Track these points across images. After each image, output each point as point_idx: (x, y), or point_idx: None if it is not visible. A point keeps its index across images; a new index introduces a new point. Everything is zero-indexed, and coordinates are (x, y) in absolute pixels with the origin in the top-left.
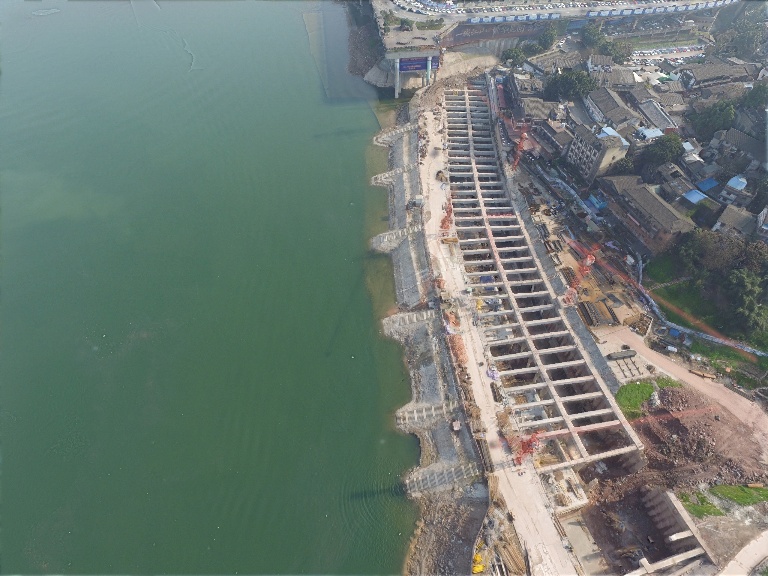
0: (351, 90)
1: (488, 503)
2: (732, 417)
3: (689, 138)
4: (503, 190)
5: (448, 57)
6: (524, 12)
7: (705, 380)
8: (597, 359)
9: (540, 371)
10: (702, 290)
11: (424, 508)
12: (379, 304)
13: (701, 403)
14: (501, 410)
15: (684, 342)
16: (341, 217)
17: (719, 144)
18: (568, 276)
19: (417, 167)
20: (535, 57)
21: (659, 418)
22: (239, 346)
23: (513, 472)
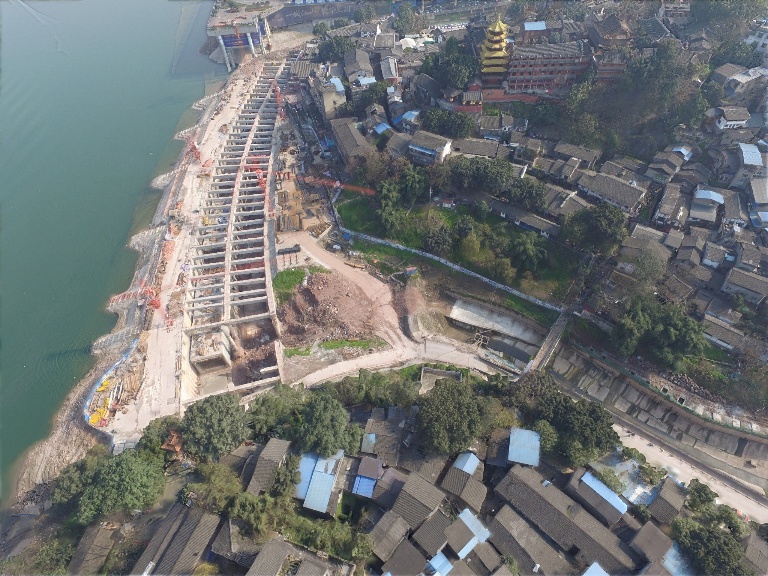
0: (194, 66)
1: (134, 350)
2: (362, 294)
3: (395, 84)
4: (270, 138)
5: (282, 36)
6: None
7: (355, 269)
8: (272, 255)
9: (225, 265)
10: (373, 202)
11: (99, 360)
12: (136, 226)
13: (340, 284)
14: (177, 290)
15: (349, 242)
16: (136, 164)
17: (415, 87)
18: (280, 197)
19: (208, 122)
20: (335, 30)
21: (305, 296)
22: (11, 257)
23: (164, 330)
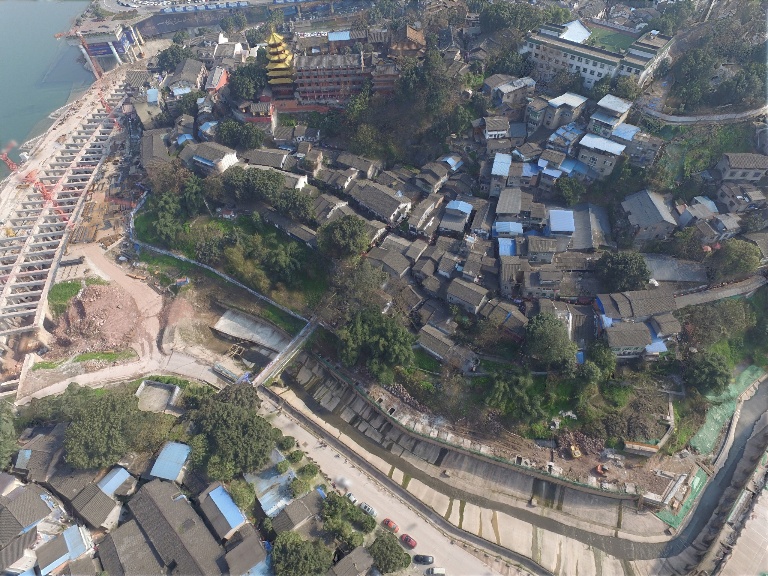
0: (67, 75)
1: None
2: (133, 306)
3: None
4: None
5: (155, 44)
6: (223, 2)
7: (135, 281)
8: None
9: (9, 277)
10: None
11: None
12: None
13: (113, 296)
14: None
15: None
16: None
17: (224, 98)
18: (85, 208)
19: (49, 132)
20: None
21: (78, 308)
22: None
23: None
